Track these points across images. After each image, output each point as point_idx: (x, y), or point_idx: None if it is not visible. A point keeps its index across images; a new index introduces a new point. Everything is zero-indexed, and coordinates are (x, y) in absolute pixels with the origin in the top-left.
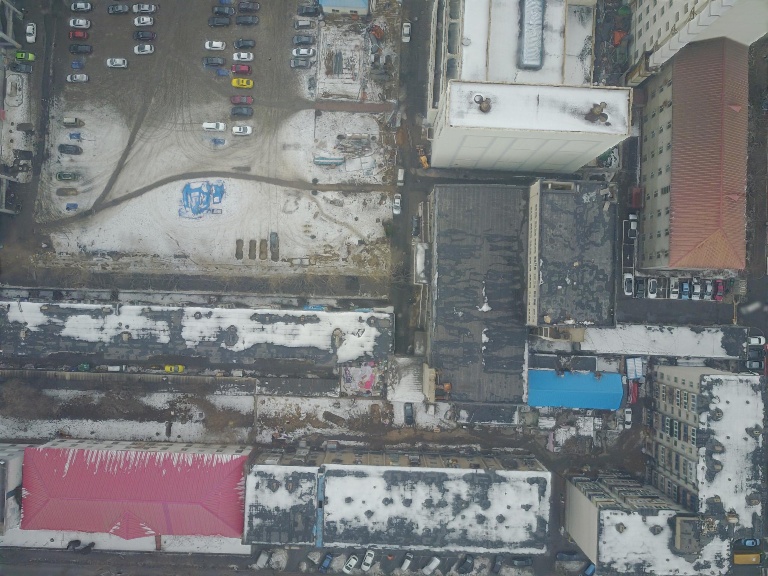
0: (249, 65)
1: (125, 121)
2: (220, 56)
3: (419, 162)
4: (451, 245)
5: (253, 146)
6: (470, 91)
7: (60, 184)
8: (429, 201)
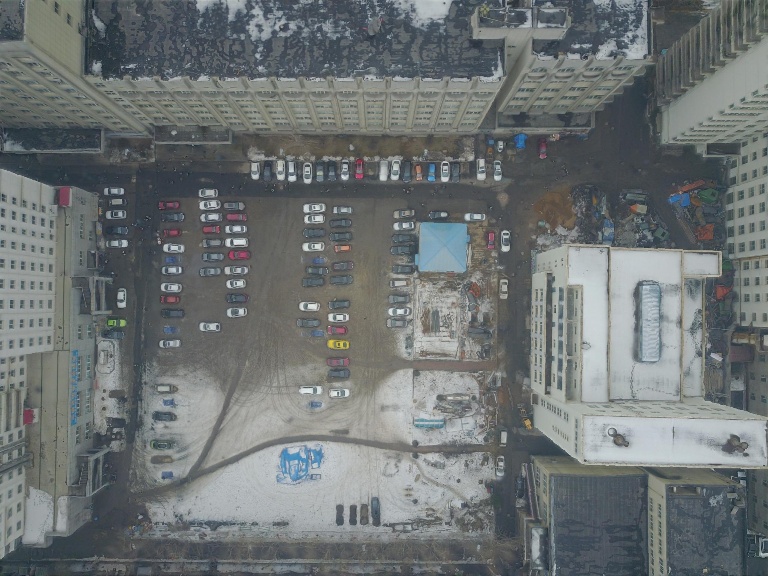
0: (344, 326)
1: (219, 385)
2: (314, 316)
3: (521, 422)
4: (569, 536)
5: (350, 408)
6: (603, 424)
7: (154, 452)
8: (533, 462)
